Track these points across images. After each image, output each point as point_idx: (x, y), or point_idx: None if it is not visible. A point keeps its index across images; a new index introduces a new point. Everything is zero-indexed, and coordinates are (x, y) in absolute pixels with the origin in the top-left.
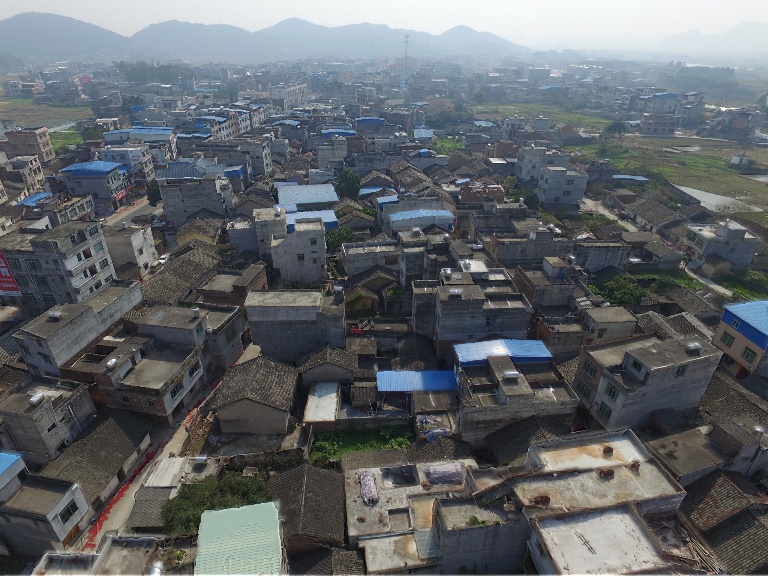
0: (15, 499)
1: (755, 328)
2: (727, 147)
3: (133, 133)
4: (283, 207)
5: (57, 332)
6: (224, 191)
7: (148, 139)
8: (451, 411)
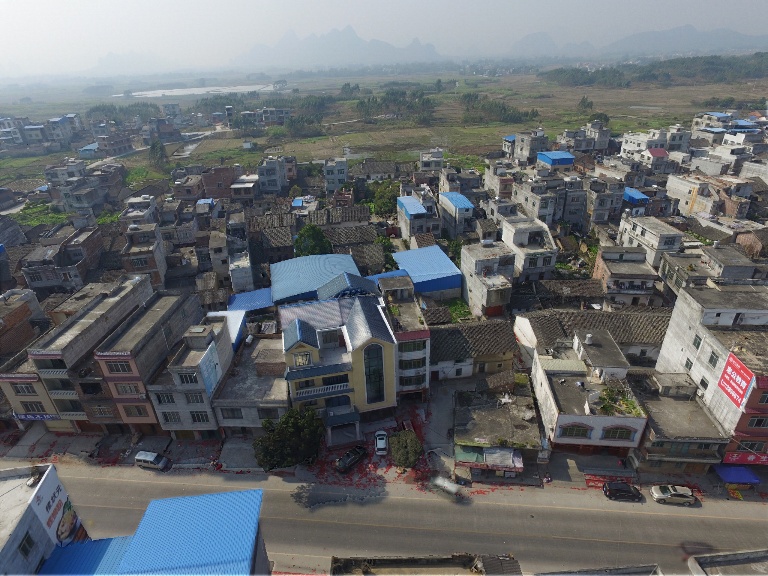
0: None
1: (568, 158)
2: None
3: None
4: (463, 246)
5: None
6: None
7: None
8: (663, 216)
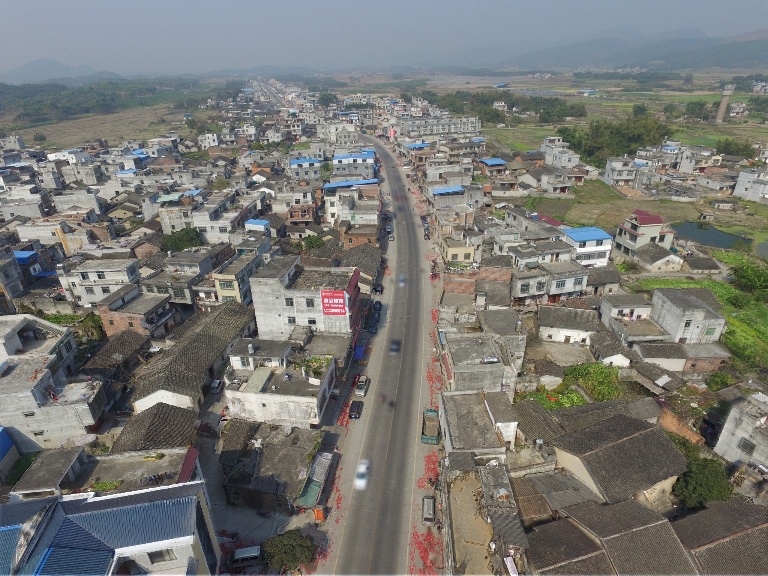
0: None
1: None
2: None
3: None
4: None
5: None
6: None
7: None
8: None
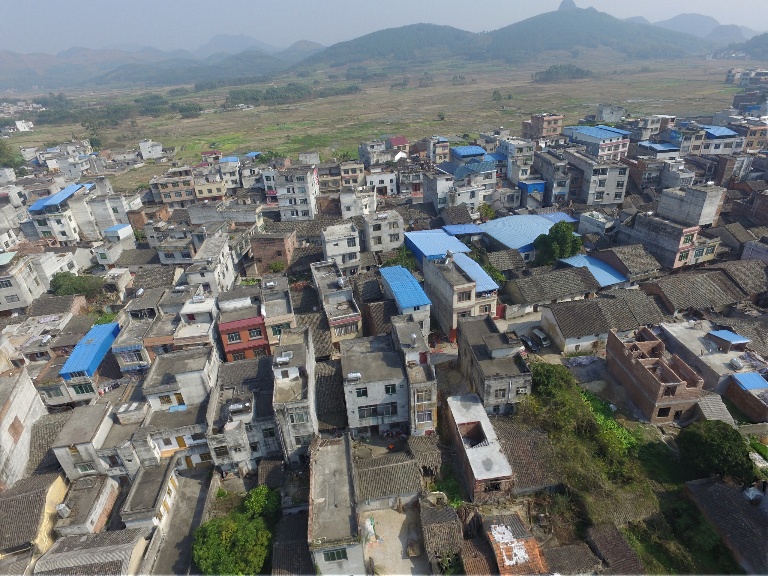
0: (112, 243)
1: None
2: None
3: (576, 131)
4: None
5: (194, 208)
6: (447, 193)
7: (585, 139)
8: None
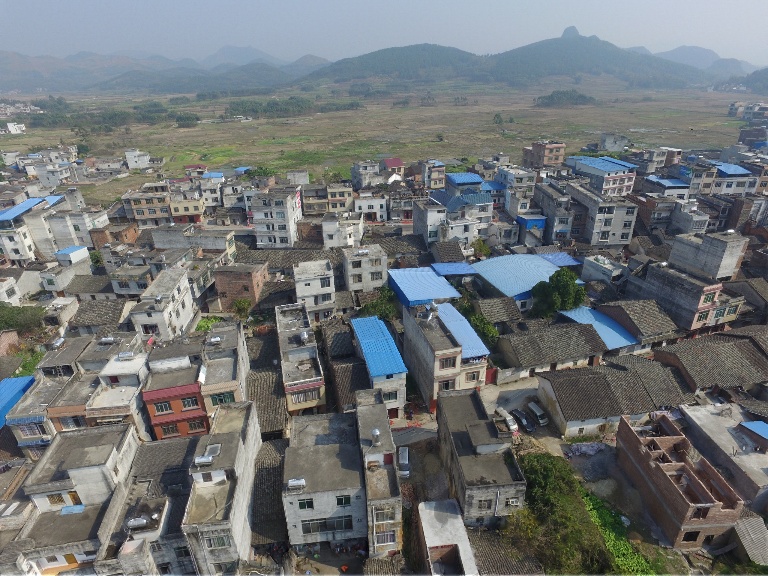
0: None
1: None
2: None
3: (580, 162)
4: None
5: (158, 231)
6: (438, 226)
7: (588, 171)
8: None
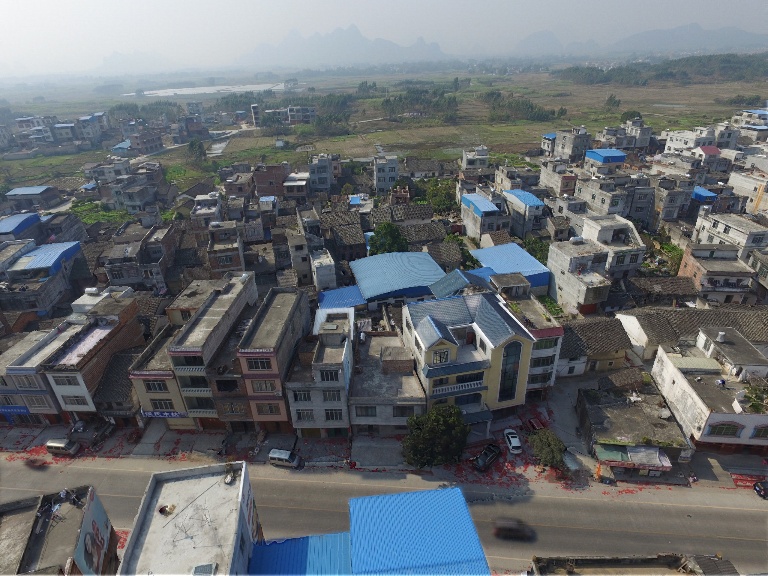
0: None
1: None
2: (211, 145)
3: None
4: None
5: None
6: None
7: None
8: None
